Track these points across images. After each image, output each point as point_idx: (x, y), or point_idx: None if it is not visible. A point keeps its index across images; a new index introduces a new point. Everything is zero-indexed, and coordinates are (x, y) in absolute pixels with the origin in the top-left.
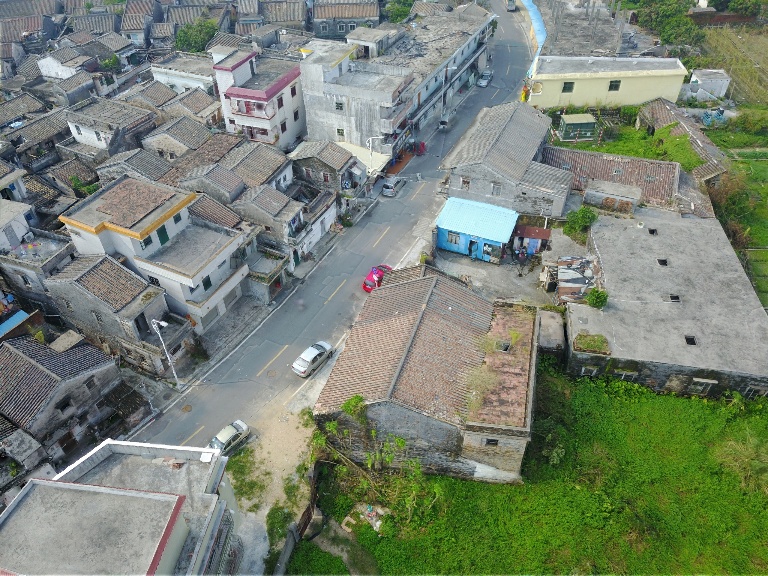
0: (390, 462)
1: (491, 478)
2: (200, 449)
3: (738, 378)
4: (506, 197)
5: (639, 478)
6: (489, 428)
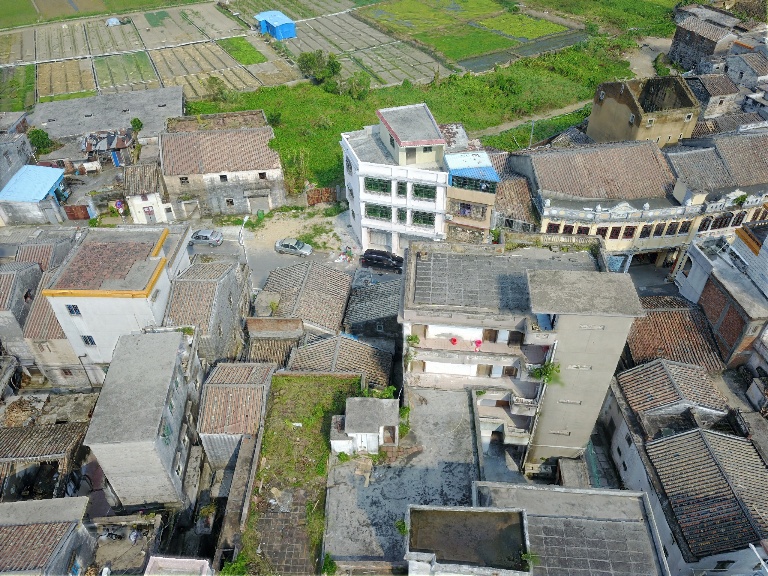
0: None
1: None
2: (344, 138)
3: None
4: (15, 159)
5: None
6: None
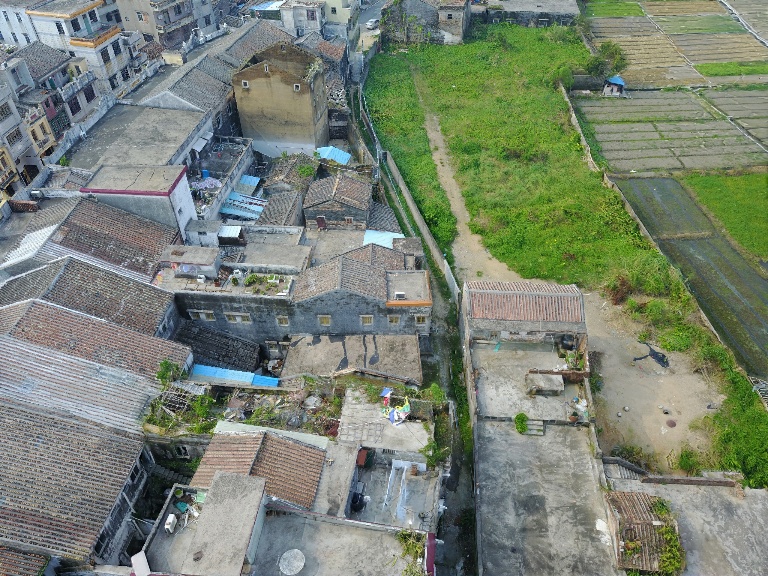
0: (411, 21)
1: (451, 42)
2: None
3: (556, 17)
4: None
5: (509, 41)
6: (448, 7)
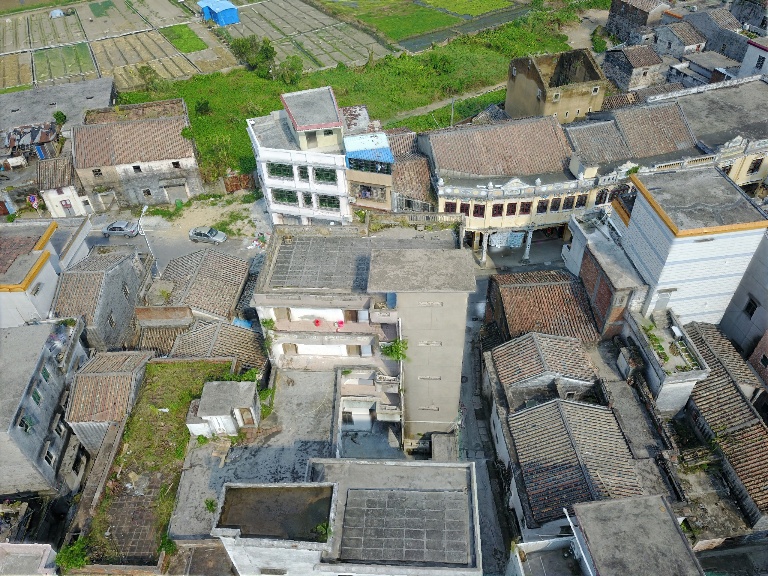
0: None
1: None
2: (249, 124)
3: (112, 92)
4: None
5: None
6: None
